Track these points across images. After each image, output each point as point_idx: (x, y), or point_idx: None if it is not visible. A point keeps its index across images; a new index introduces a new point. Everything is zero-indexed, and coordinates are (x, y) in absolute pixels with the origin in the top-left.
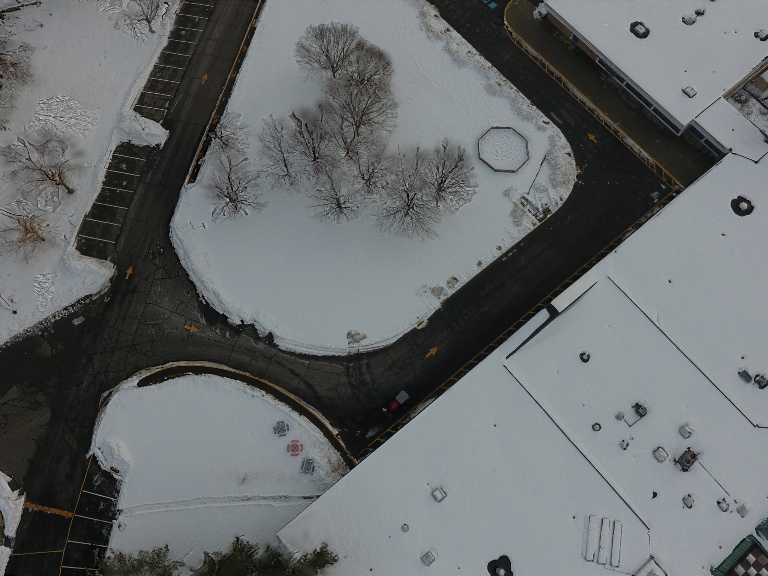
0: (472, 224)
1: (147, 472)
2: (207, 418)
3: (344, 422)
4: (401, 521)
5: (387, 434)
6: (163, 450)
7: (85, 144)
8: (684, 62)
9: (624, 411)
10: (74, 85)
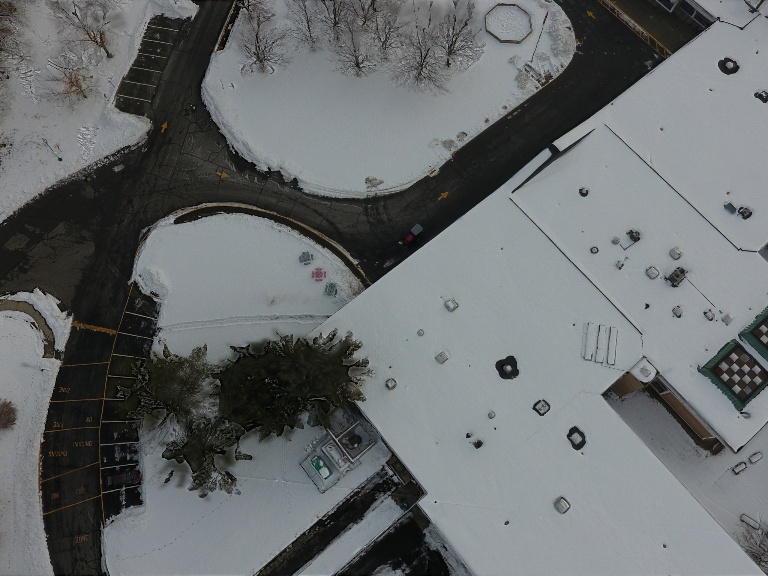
0: (480, 87)
1: (184, 295)
2: (238, 250)
3: (363, 254)
4: (417, 327)
5: None
6: (198, 277)
7: (122, 16)
8: None
9: (619, 237)
10: None
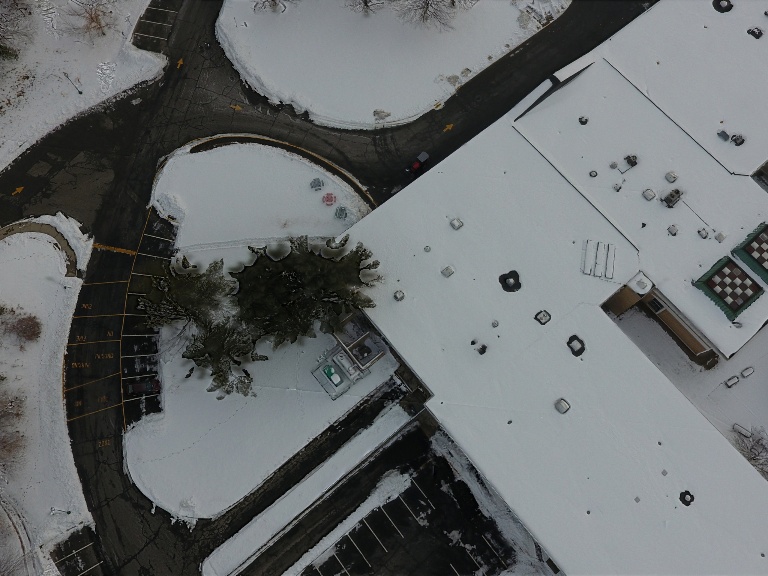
0: (483, 27)
1: (200, 219)
2: (252, 177)
3: (372, 181)
4: (424, 244)
5: None
6: (214, 202)
7: None
8: None
9: (617, 161)
10: None
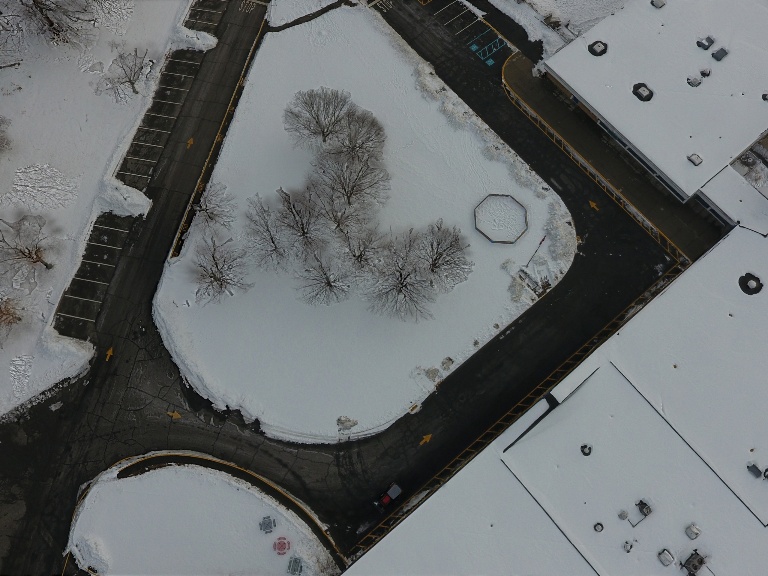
0: (468, 300)
1: (126, 572)
2: (190, 513)
3: (334, 517)
4: None
5: (379, 530)
6: (143, 548)
7: (65, 215)
8: (689, 127)
9: (627, 510)
10: (53, 152)
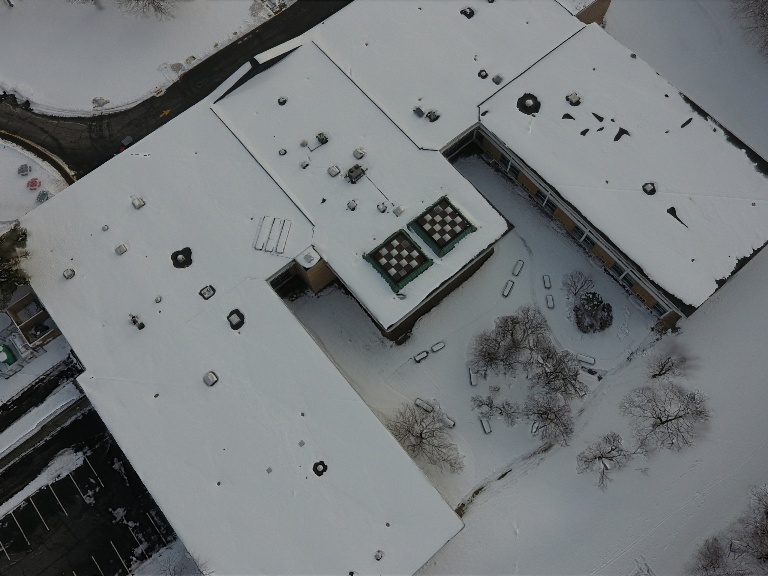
0: (215, 16)
1: None
2: None
3: (81, 166)
4: (103, 223)
5: None
6: None
7: None
8: None
9: (308, 140)
10: None
